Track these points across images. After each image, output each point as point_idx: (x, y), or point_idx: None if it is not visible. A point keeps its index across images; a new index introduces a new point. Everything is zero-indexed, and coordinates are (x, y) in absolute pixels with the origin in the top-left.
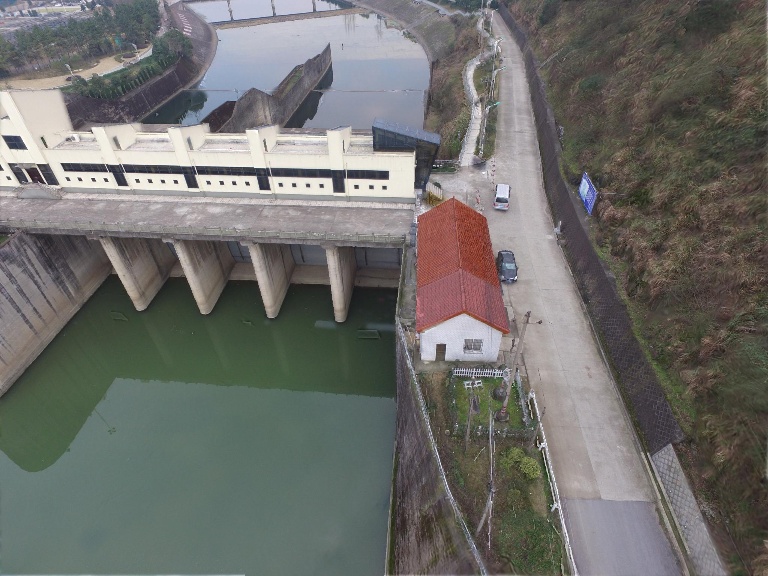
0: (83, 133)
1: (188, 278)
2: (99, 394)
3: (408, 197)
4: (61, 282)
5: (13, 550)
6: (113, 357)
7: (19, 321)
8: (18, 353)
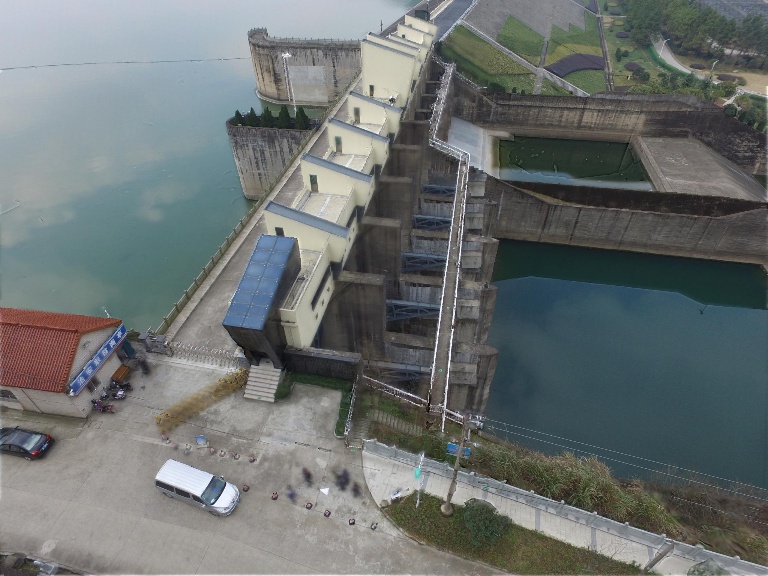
0: None
1: None
2: None
3: None
4: None
5: (139, 233)
6: None
7: None
8: None
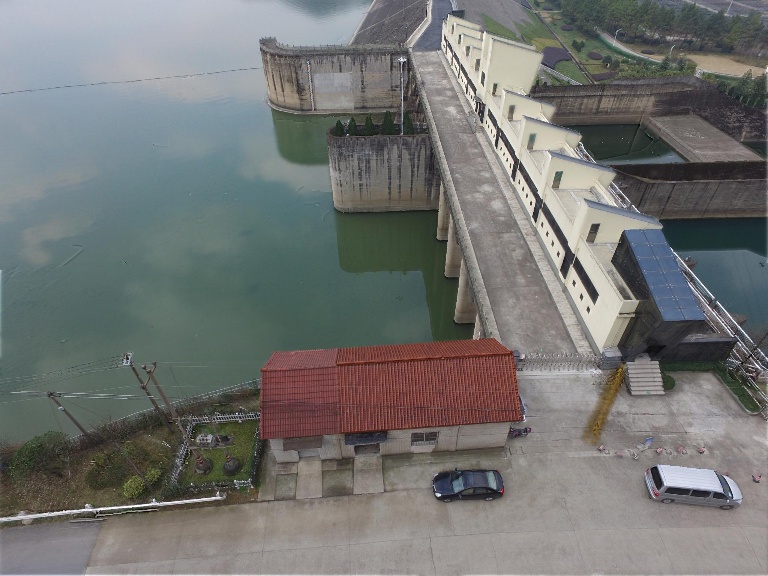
0: None
1: (448, 238)
2: (401, 268)
3: (597, 345)
4: (430, 184)
5: (249, 262)
6: (425, 257)
7: (386, 184)
8: (372, 200)
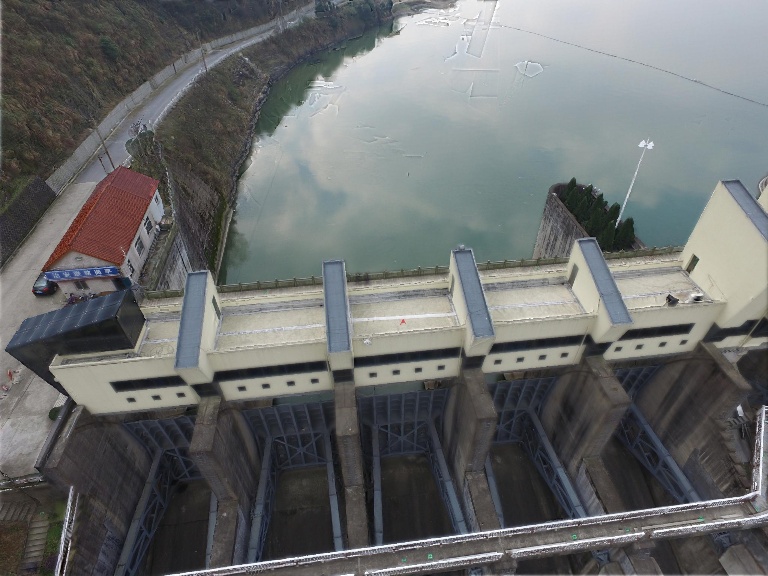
0: (695, 305)
1: None
2: None
3: None
4: None
5: (423, 229)
6: None
7: None
8: None
